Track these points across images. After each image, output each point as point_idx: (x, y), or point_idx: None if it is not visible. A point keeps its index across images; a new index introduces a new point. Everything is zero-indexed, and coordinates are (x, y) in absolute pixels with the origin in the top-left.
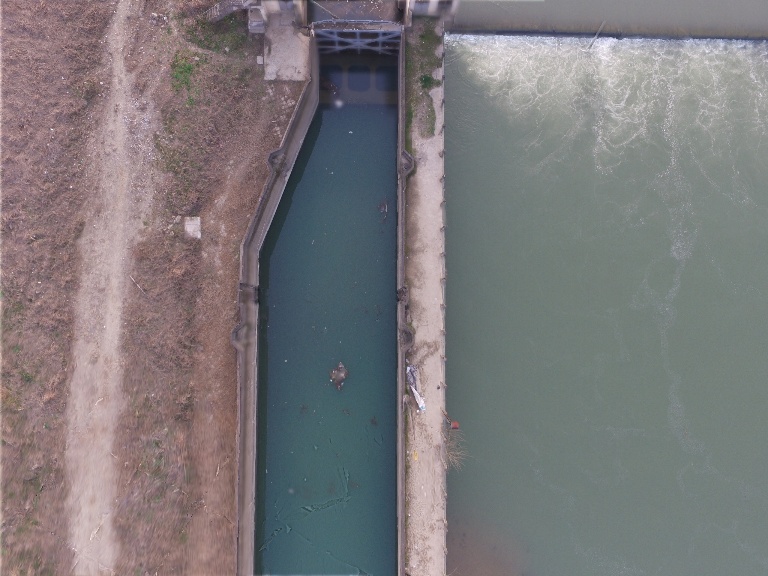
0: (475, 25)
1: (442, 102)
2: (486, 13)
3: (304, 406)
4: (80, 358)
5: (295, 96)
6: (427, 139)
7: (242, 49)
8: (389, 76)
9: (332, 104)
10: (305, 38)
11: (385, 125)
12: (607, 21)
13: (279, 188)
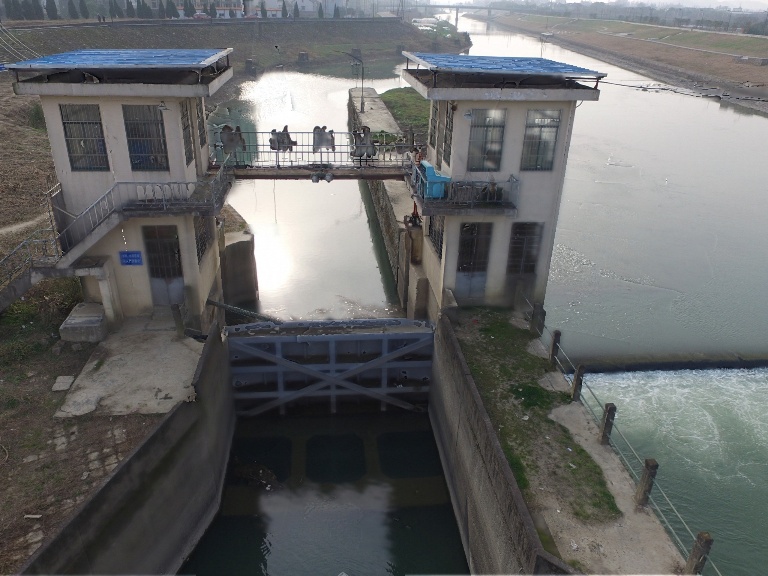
0: (577, 358)
1: (605, 416)
2: (587, 346)
3: None
4: None
5: None
6: (603, 527)
7: (24, 366)
8: (413, 449)
9: (258, 513)
10: (201, 345)
11: (424, 557)
12: None
13: None
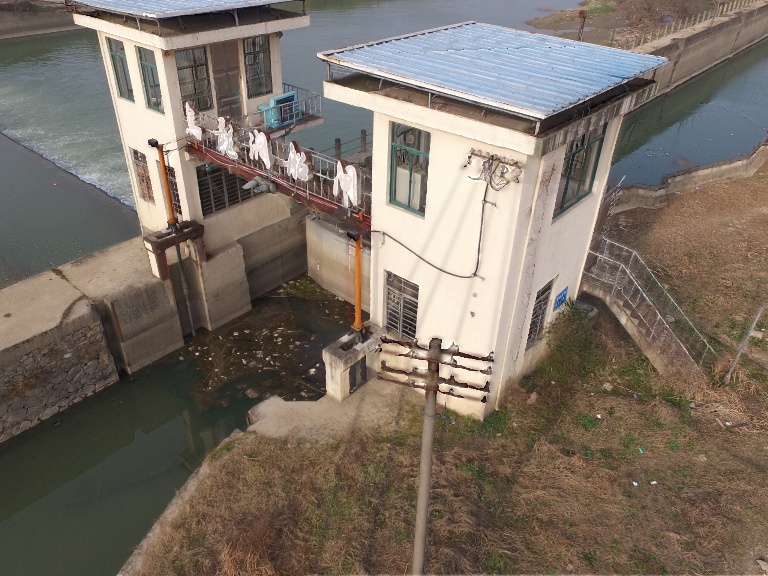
0: None
1: None
2: None
3: (711, 156)
4: None
5: None
6: None
7: None
8: None
9: None
10: None
11: None
12: (58, 181)
13: None
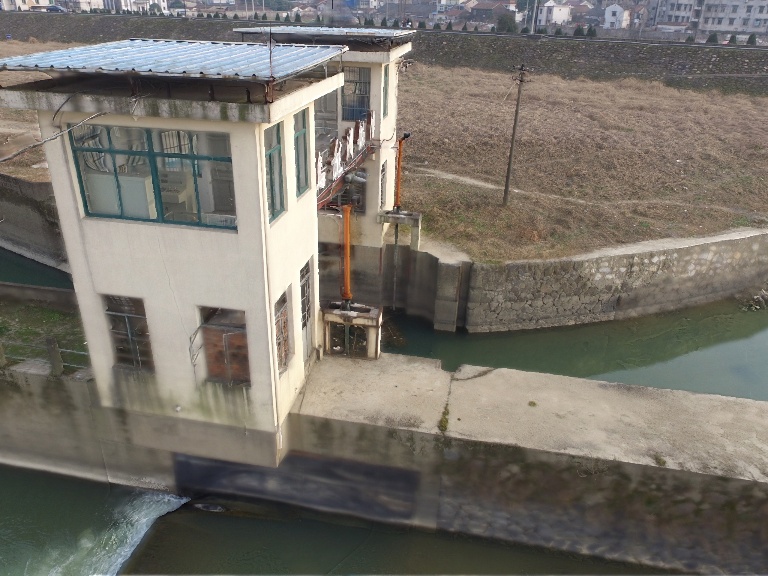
0: None
1: None
2: None
3: None
4: (0, 121)
5: None
6: None
7: None
8: None
9: None
10: None
11: None
12: None
13: (40, 237)
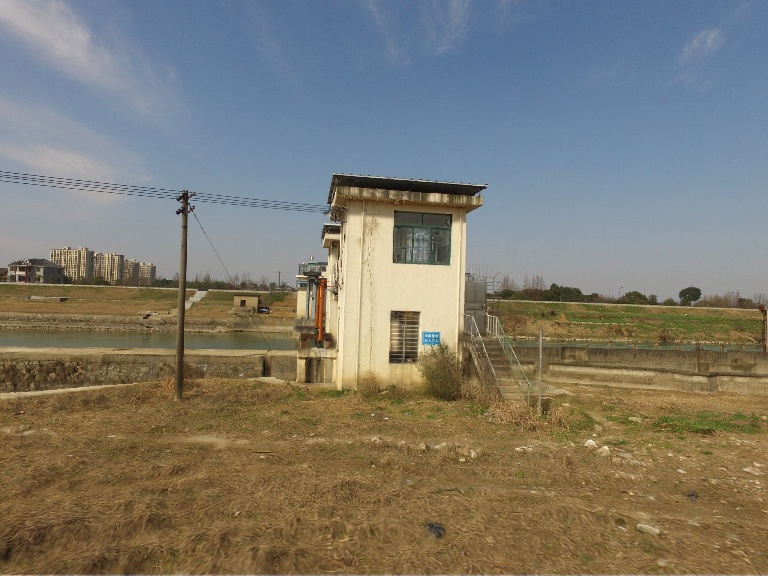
0: None
1: None
2: None
3: None
4: None
5: (571, 385)
6: None
7: None
8: None
9: None
10: None
11: None
12: None
13: None
